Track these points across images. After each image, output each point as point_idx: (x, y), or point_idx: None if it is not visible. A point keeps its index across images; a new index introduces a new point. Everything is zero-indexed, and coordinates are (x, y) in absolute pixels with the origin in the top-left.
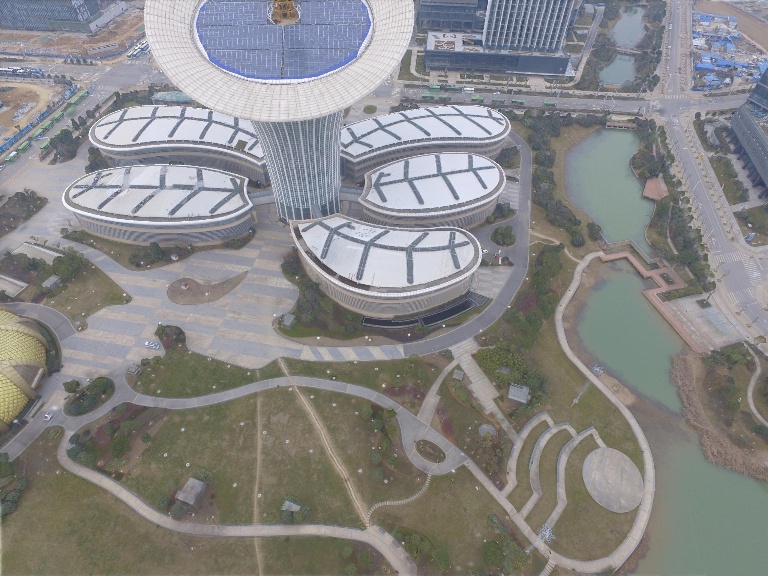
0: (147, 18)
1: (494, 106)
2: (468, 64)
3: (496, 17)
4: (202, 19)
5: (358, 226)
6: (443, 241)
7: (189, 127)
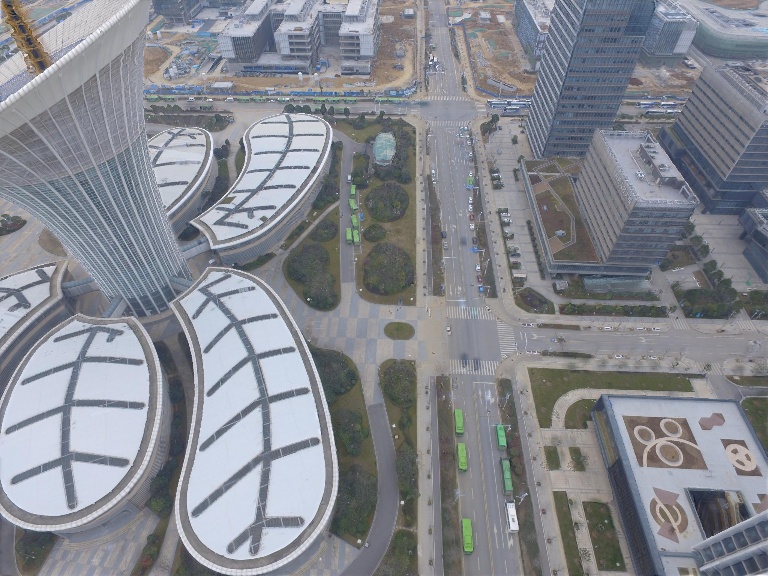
0: (60, 24)
1: (393, 563)
2: (626, 514)
3: (756, 556)
4: None
5: (15, 314)
6: None
7: (266, 159)
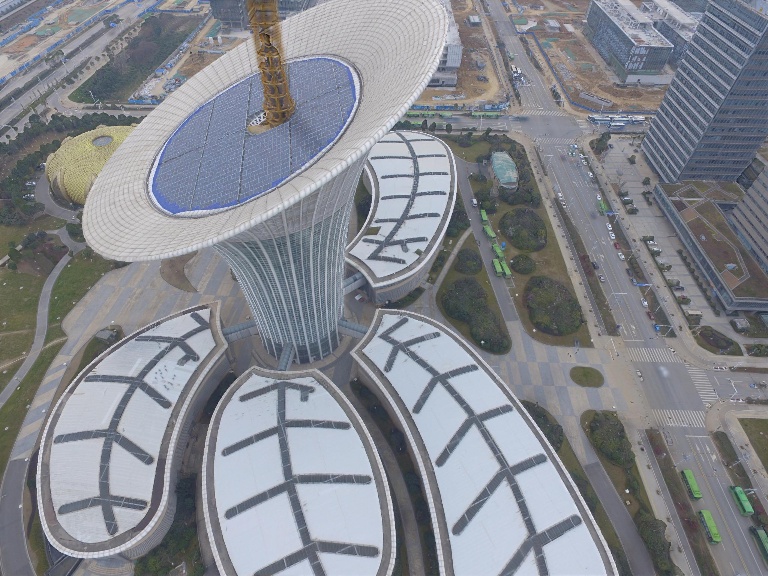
0: (240, 45)
1: None
2: None
3: None
4: (261, 74)
5: (186, 369)
6: (121, 486)
7: (398, 184)
